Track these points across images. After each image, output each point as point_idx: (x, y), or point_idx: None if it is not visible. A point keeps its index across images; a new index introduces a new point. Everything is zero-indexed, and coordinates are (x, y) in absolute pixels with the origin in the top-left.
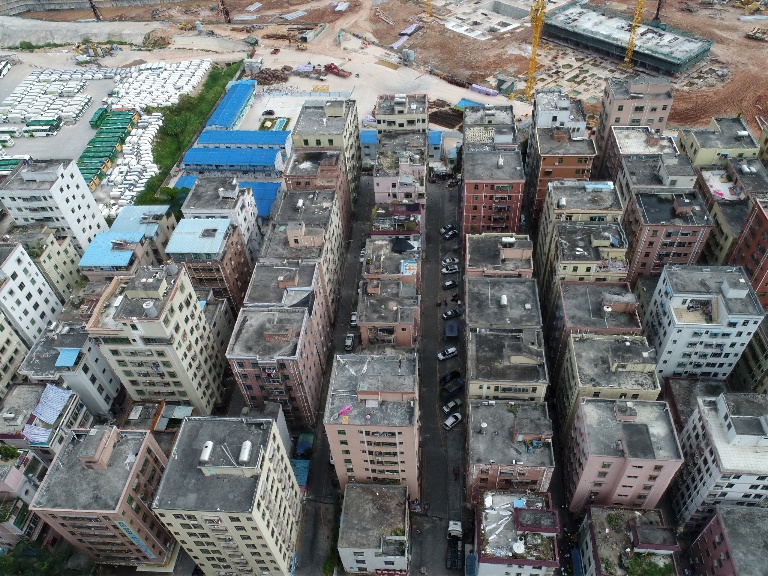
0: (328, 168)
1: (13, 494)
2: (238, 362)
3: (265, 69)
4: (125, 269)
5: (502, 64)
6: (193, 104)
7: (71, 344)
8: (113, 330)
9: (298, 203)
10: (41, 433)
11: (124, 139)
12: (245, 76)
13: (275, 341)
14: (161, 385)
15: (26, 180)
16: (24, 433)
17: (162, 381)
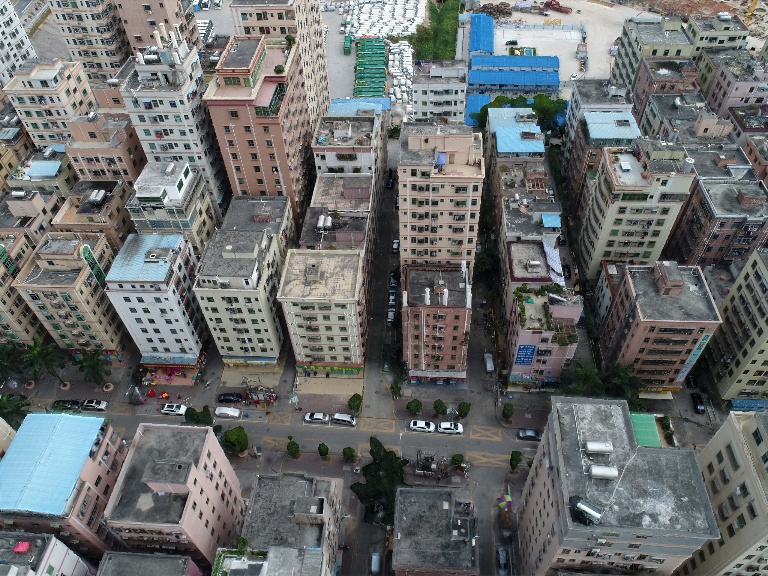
0: (689, 74)
1: (574, 321)
2: (722, 222)
3: (489, 4)
4: (539, 156)
5: (696, 7)
6: (429, 35)
7: (549, 210)
8: (642, 186)
9: (678, 102)
10: (558, 279)
11: (387, 63)
12: (466, 11)
13: (749, 205)
14: (634, 246)
15: (432, 76)
16: (551, 277)
17: (640, 241)
